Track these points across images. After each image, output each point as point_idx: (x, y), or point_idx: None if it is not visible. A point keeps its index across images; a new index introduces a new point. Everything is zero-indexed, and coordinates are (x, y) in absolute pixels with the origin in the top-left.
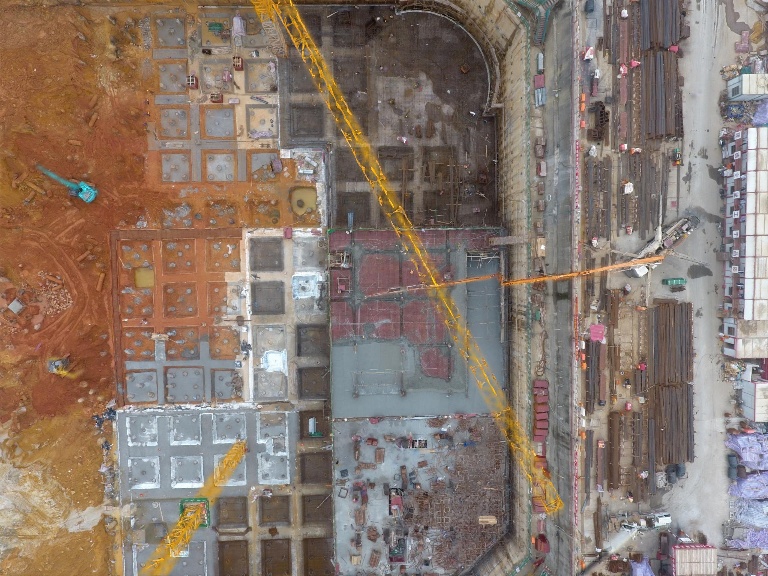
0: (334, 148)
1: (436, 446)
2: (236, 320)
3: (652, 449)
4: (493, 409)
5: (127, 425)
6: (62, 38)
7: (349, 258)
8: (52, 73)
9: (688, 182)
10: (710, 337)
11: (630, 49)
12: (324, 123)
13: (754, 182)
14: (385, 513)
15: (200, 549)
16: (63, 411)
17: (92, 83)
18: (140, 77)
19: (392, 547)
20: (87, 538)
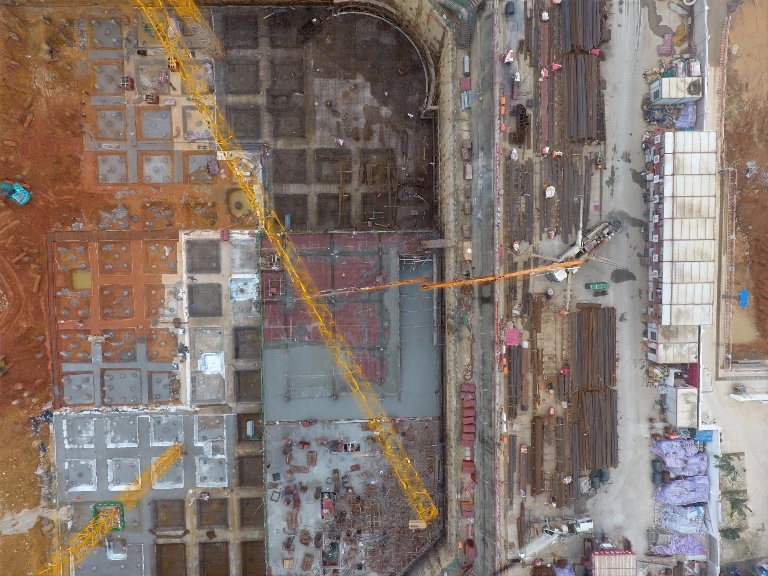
0: (271, 150)
1: (369, 450)
2: (173, 322)
3: (575, 454)
4: (426, 413)
5: (64, 427)
6: None
7: (280, 261)
8: None
9: (611, 186)
10: (634, 342)
11: (552, 52)
12: (261, 125)
13: (671, 186)
14: (318, 517)
15: (138, 552)
16: None
17: (27, 84)
18: (75, 78)
19: (326, 551)
20: (22, 540)
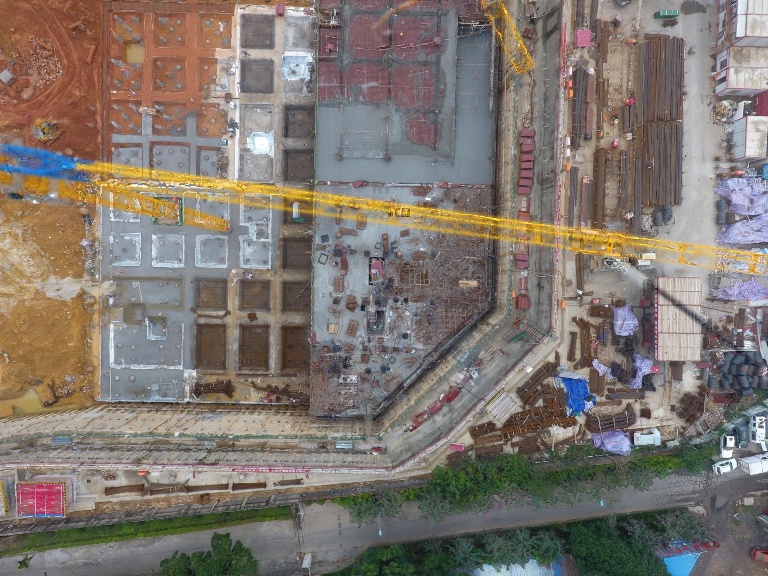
0: None
1: None
2: (224, 97)
3: (638, 189)
4: (479, 180)
5: (110, 200)
6: None
7: (339, 16)
8: None
9: None
10: (702, 77)
11: None
12: None
13: None
14: (365, 282)
15: (178, 332)
16: (47, 183)
17: None
18: None
19: (371, 322)
20: (64, 308)
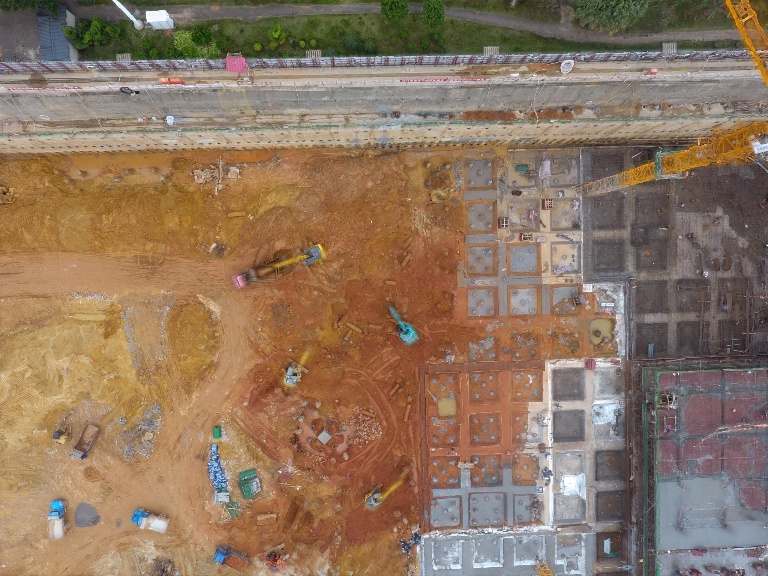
0: (634, 282)
1: (753, 575)
2: (538, 448)
3: None
4: None
5: (432, 549)
6: (388, 187)
7: (676, 399)
8: (383, 223)
9: None
10: None
11: None
12: (625, 258)
13: None
14: None
15: None
16: (371, 537)
17: (407, 226)
18: (451, 218)
19: None
20: None
